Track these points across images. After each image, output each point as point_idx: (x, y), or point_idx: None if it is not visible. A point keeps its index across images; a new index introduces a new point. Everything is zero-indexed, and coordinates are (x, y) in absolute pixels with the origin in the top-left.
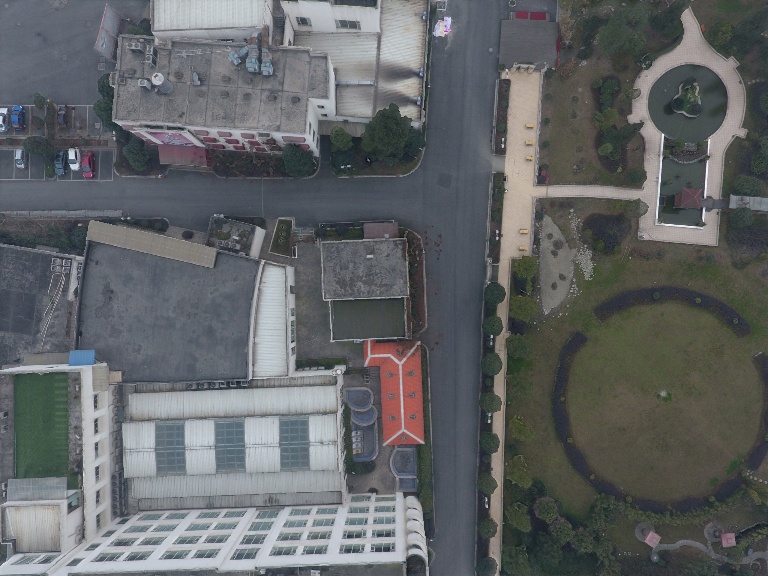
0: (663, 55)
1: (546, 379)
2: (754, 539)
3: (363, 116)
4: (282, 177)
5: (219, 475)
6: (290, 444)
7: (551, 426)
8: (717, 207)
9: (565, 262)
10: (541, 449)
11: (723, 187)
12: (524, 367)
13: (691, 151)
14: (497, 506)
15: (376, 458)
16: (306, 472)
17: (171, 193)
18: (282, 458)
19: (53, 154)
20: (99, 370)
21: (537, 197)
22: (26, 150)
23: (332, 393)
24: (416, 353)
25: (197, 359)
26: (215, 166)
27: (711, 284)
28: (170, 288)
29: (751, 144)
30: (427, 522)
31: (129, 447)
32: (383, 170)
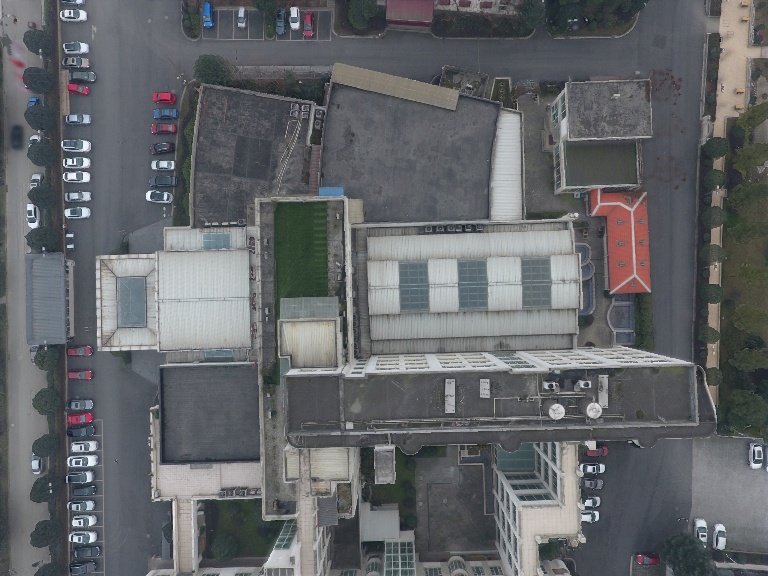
0: None
1: None
2: None
3: None
4: (499, 38)
5: (455, 317)
6: (532, 282)
7: None
8: None
9: None
10: (756, 305)
11: None
12: None
13: None
14: (713, 360)
15: (593, 313)
16: (541, 314)
17: (388, 53)
18: (524, 296)
19: (273, 14)
20: (354, 203)
21: (752, 58)
22: (256, 4)
23: (567, 237)
24: (643, 203)
25: (437, 201)
26: (434, 25)
27: None
28: (410, 131)
29: None
30: None
31: (374, 284)
32: (599, 31)
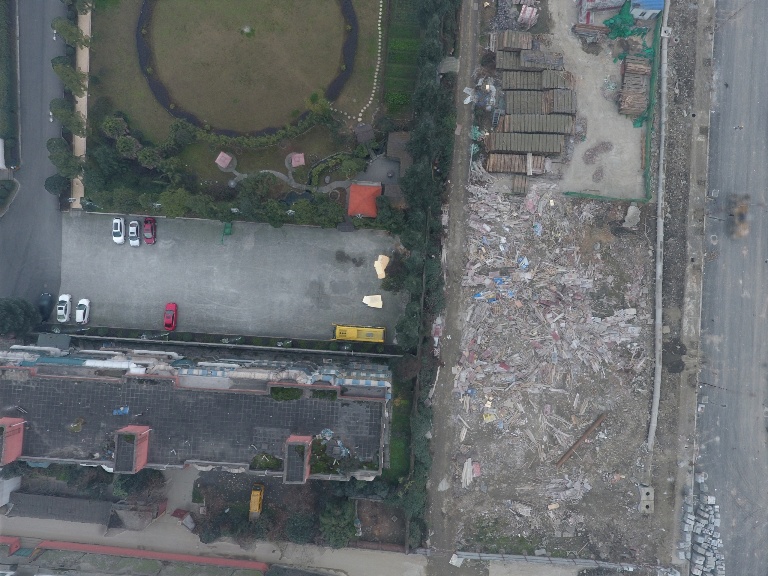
0: None
1: (132, 16)
2: (328, 164)
3: None
4: None
5: None
6: None
7: (136, 61)
8: None
9: None
10: (127, 84)
11: None
12: (110, 4)
13: None
14: (82, 138)
15: None
16: None
17: None
18: None
19: None
20: None
21: None
22: None
23: None
24: None
25: None
26: None
27: None
28: None
29: None
30: (9, 151)
31: None
32: None
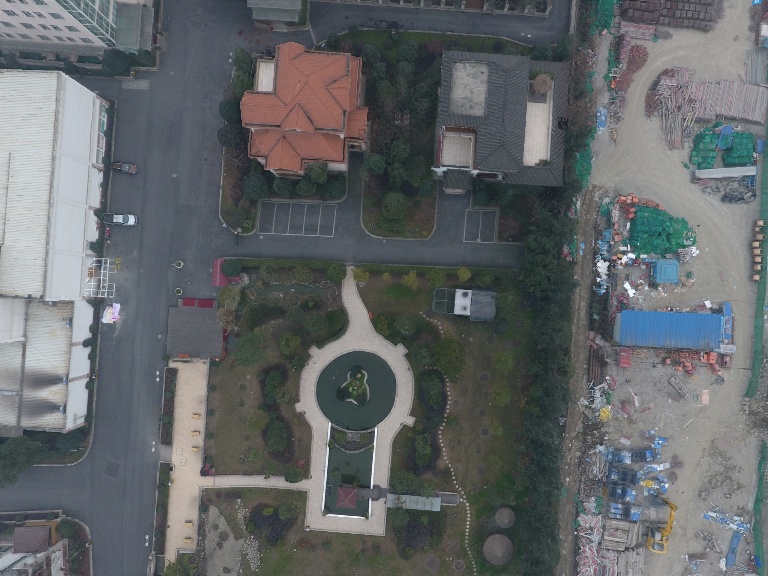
0: (331, 342)
1: None
2: None
3: (8, 424)
4: None
5: None
6: None
7: None
8: (385, 496)
9: (230, 554)
10: None
11: (391, 476)
12: None
13: (357, 441)
14: None
15: None
16: None
17: None
18: None
19: None
20: None
21: (203, 487)
22: None
23: None
24: None
25: None
26: None
27: (378, 574)
28: None
29: (417, 434)
30: None
31: None
32: None
